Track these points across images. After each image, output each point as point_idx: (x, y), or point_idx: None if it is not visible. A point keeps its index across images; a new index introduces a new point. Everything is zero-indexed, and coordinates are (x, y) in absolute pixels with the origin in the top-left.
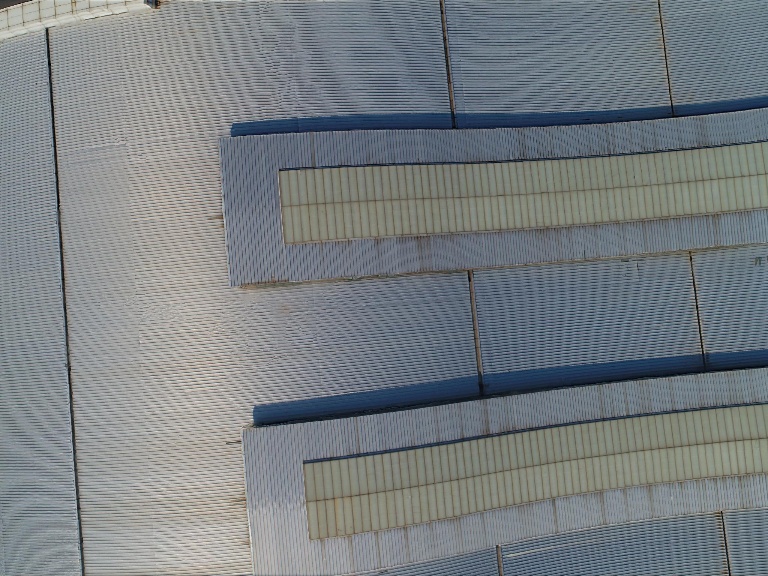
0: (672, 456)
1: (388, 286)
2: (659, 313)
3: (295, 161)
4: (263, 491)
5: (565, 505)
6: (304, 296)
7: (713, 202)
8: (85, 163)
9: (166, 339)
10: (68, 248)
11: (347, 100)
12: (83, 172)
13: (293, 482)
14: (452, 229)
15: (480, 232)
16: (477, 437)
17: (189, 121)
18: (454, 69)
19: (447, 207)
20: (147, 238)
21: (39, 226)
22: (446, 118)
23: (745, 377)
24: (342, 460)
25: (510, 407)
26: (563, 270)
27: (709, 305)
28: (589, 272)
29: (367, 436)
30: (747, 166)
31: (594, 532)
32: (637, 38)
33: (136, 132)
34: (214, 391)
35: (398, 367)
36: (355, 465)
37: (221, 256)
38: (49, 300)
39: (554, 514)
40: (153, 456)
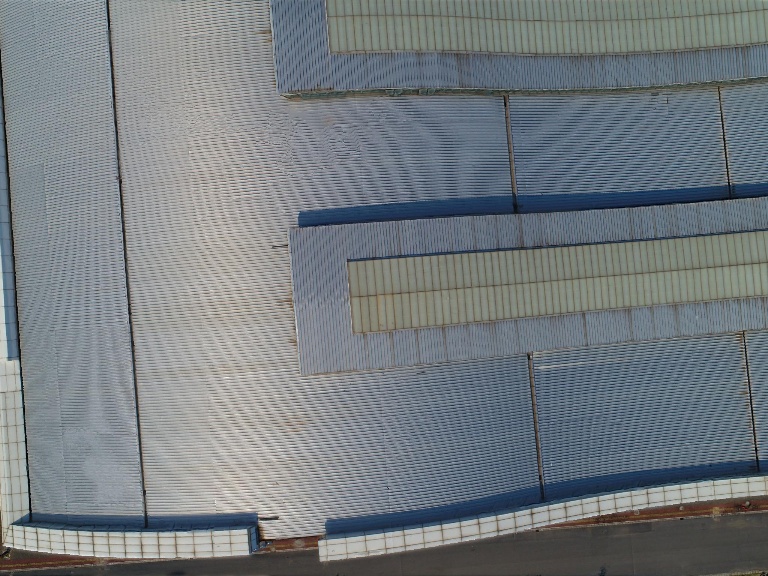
0: (698, 277)
1: (428, 104)
2: (687, 145)
3: None
4: (309, 287)
5: (595, 319)
6: (347, 109)
7: (743, 34)
8: None
9: (214, 149)
10: (119, 65)
11: None
12: None
13: (337, 279)
14: (490, 49)
15: (517, 55)
16: (512, 248)
17: None
18: None
19: (486, 27)
20: (196, 52)
21: (90, 46)
22: None
23: None
24: (384, 260)
25: (543, 223)
26: (595, 101)
27: (736, 138)
28: (620, 104)
29: (408, 239)
30: None
31: (621, 351)
32: None
33: None
34: (261, 198)
35: (437, 181)
36: (397, 265)
37: (268, 69)
38: (100, 117)
39: (584, 327)
40: (202, 260)
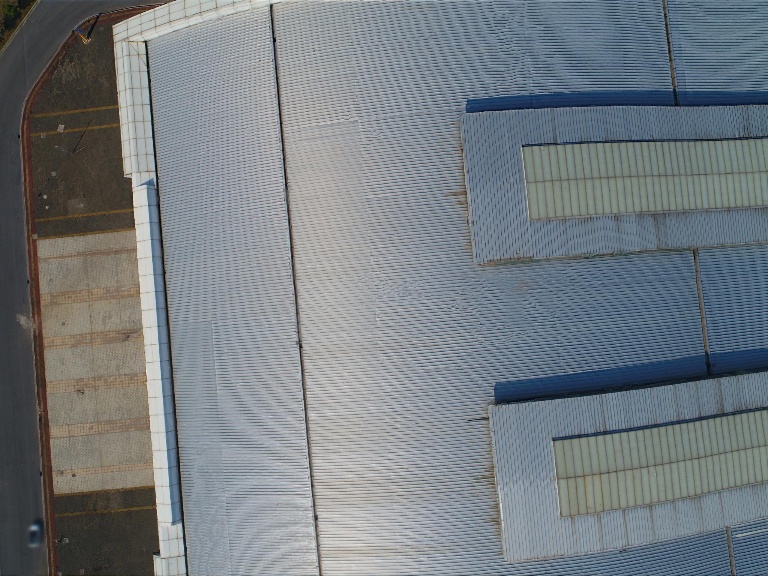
0: None
1: (621, 264)
2: None
3: (537, 137)
4: (514, 468)
5: None
6: (542, 273)
7: None
8: (315, 140)
9: (404, 316)
10: (297, 225)
11: (578, 76)
12: (313, 149)
13: (543, 459)
14: (686, 207)
15: (710, 210)
16: (713, 416)
17: (423, 97)
18: (675, 46)
19: (681, 184)
20: (382, 215)
21: (265, 203)
22: (669, 95)
23: None
24: (590, 437)
25: (742, 386)
26: None
27: None
28: None
29: (613, 414)
30: None
31: None
32: None
33: (368, 108)
34: (454, 368)
35: (633, 345)
36: (603, 443)
37: (459, 233)
38: (277, 278)
39: None
40: (392, 433)
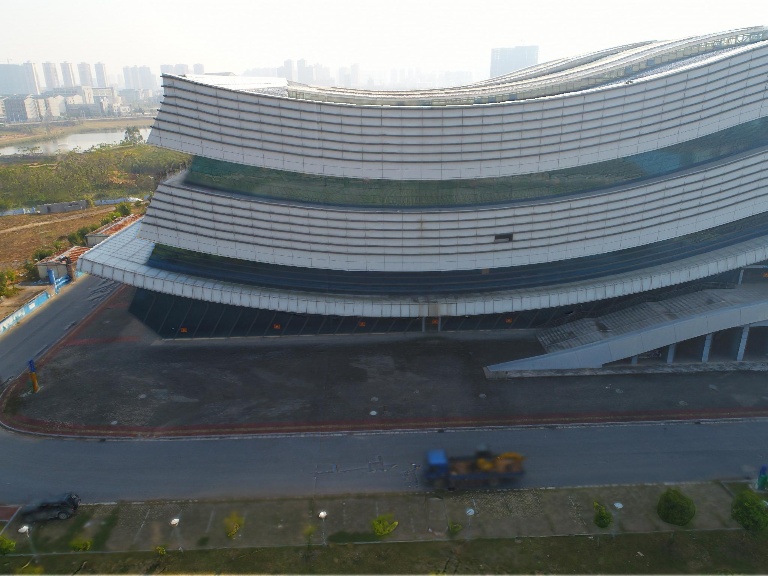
0: None
1: None
2: None
3: None
4: None
5: None
6: None
7: None
8: None
9: None
10: None
11: None
12: None
13: None
14: None
15: None
16: None
17: None
18: None
19: None
20: None
21: None
22: None
23: None
24: None
25: None
26: None
27: None
28: None
29: None
30: None
31: None
32: None
33: None
34: None
35: None
36: None
37: None
38: None
39: None
40: None
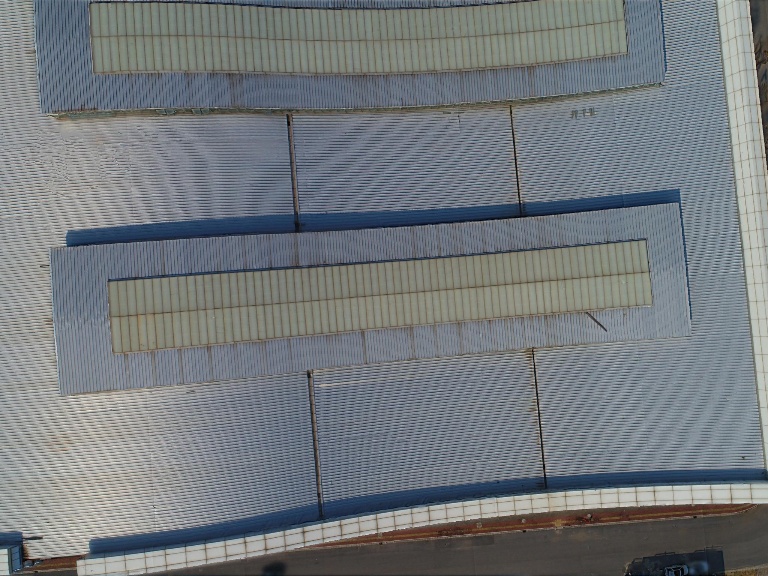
0: (481, 295)
1: (203, 123)
2: (478, 164)
3: None
4: (69, 306)
5: (374, 338)
6: (118, 128)
7: (528, 54)
8: None
9: None
10: None
11: None
12: None
13: (98, 299)
14: (265, 69)
15: (295, 74)
16: (286, 267)
17: None
18: None
19: (261, 47)
20: None
21: None
22: None
23: (554, 222)
24: (146, 280)
25: (321, 242)
26: (385, 120)
27: (527, 157)
28: (411, 123)
29: (173, 259)
30: (562, 19)
31: (408, 369)
32: None
33: None
34: (29, 217)
35: (211, 200)
36: (159, 285)
37: (38, 88)
38: None
39: (363, 346)
40: None
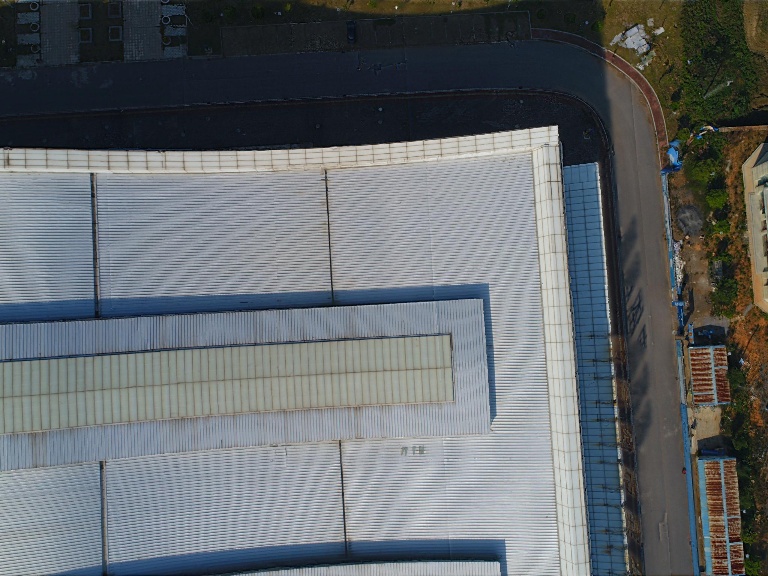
0: None
1: (5, 479)
2: (304, 499)
3: None
4: None
5: None
6: None
7: (355, 395)
8: None
9: None
10: None
11: None
12: None
13: None
14: (72, 424)
15: (106, 425)
16: None
17: None
18: (102, 254)
19: (68, 402)
20: None
21: None
22: (88, 304)
23: (375, 571)
24: None
25: None
26: (207, 455)
27: (354, 493)
28: (235, 457)
29: None
30: (389, 361)
31: None
32: (302, 221)
33: None
34: None
35: (9, 561)
36: None
37: None
38: None
39: None
40: None
